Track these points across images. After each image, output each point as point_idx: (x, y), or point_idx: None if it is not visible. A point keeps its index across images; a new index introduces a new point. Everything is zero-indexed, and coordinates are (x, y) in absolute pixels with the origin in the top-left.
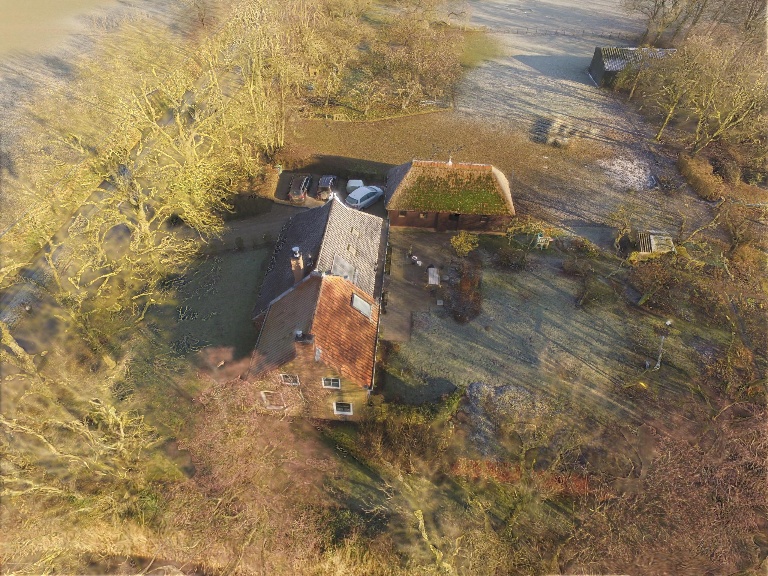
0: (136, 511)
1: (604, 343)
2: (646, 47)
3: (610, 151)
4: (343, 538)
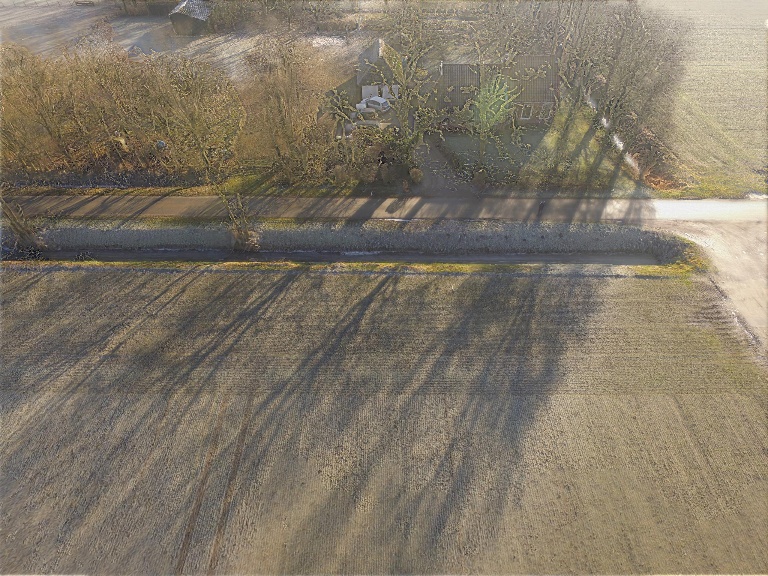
0: (615, 145)
1: (468, 58)
2: (180, 2)
3: (303, 42)
4: (587, 104)
